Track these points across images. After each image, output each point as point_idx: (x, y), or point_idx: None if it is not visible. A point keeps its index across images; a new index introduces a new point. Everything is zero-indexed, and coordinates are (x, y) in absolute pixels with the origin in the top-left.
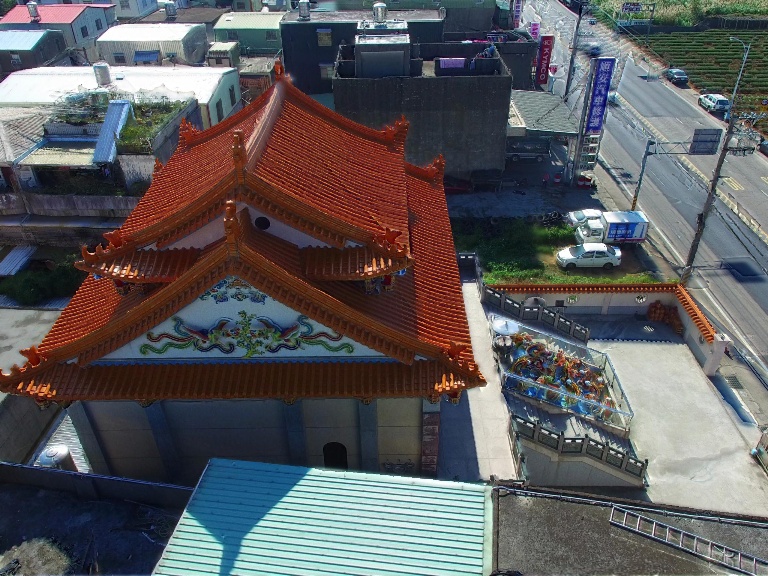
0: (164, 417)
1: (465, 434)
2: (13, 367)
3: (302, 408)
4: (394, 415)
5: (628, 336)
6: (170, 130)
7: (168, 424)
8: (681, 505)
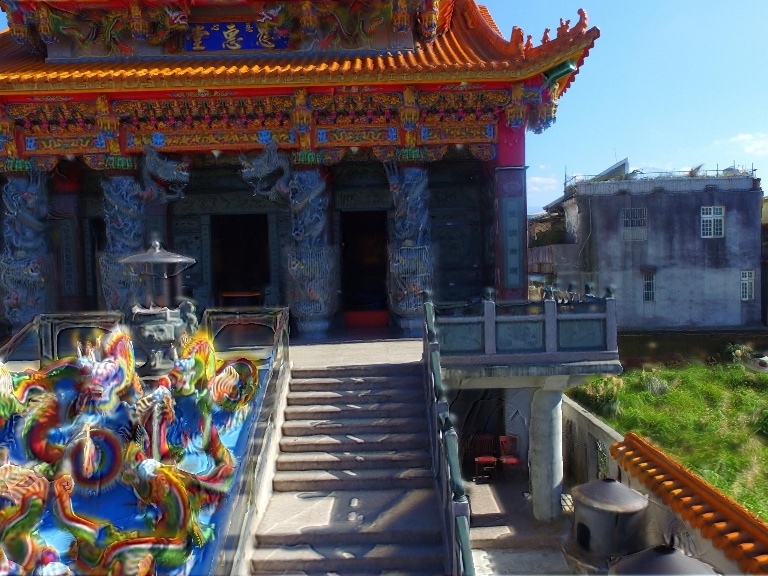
0: None
1: None
2: None
3: None
4: None
5: None
6: (642, 188)
7: None
8: None
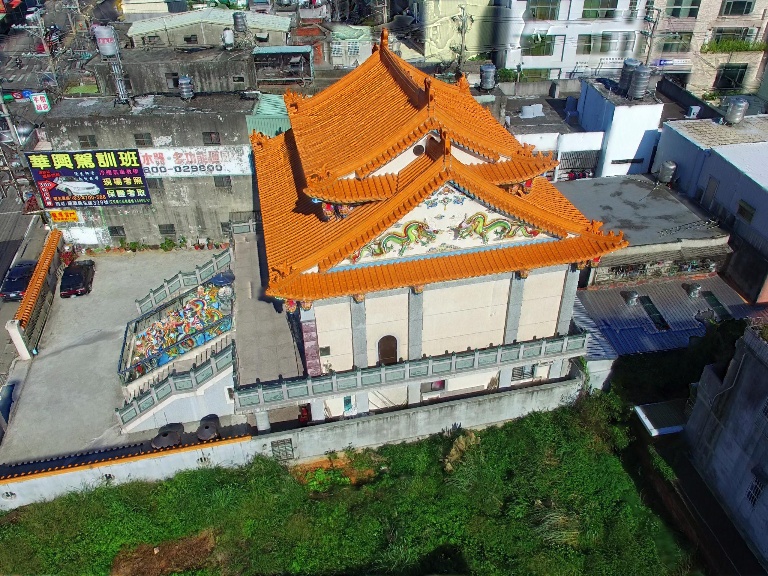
0: None
1: (265, 256)
2: None
3: None
4: None
5: (60, 463)
6: None
7: None
8: (121, 314)
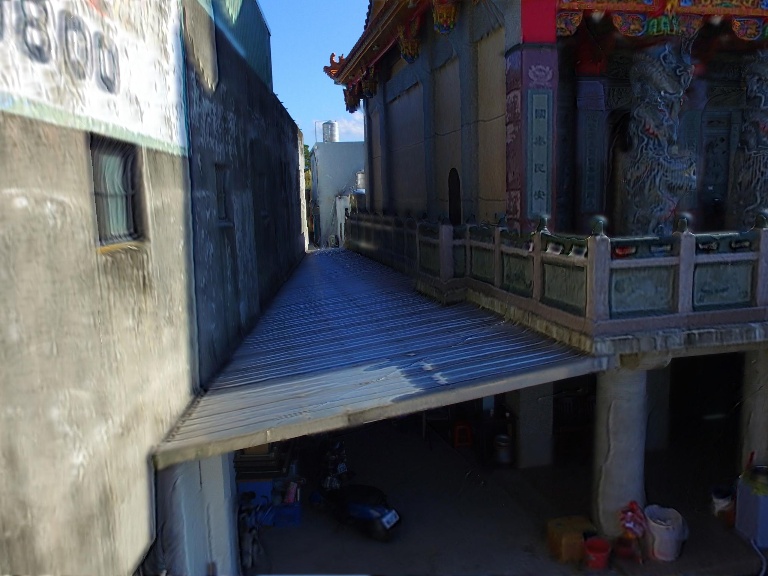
0: (385, 127)
1: None
2: (341, 57)
3: (434, 90)
4: (493, 87)
5: None
6: None
7: (387, 141)
8: None
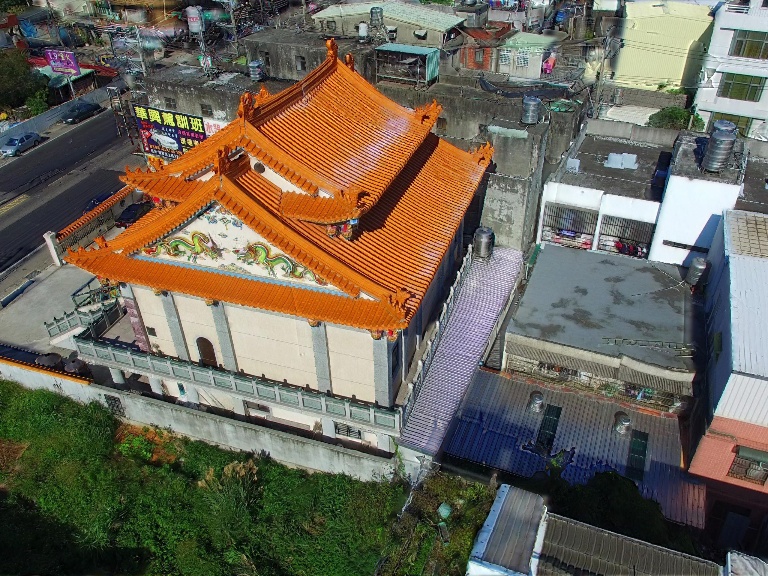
0: None
1: None
2: None
3: None
4: None
5: (1, 349)
6: None
7: None
8: None
